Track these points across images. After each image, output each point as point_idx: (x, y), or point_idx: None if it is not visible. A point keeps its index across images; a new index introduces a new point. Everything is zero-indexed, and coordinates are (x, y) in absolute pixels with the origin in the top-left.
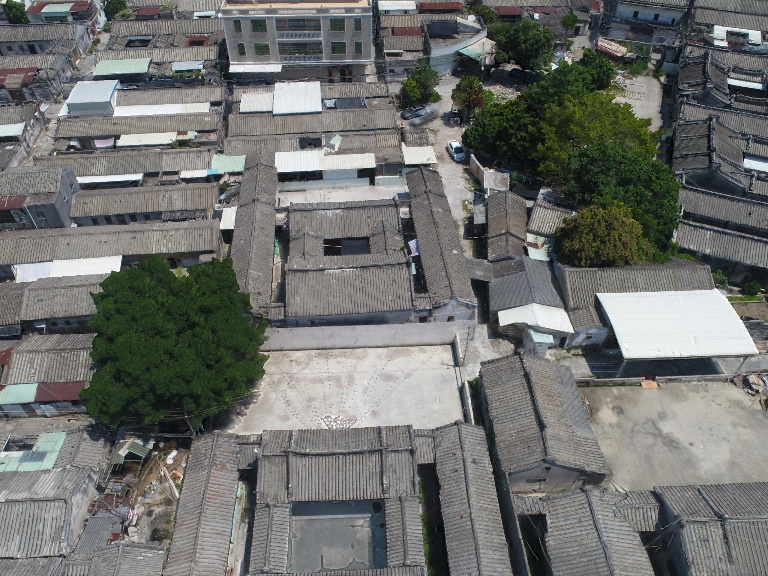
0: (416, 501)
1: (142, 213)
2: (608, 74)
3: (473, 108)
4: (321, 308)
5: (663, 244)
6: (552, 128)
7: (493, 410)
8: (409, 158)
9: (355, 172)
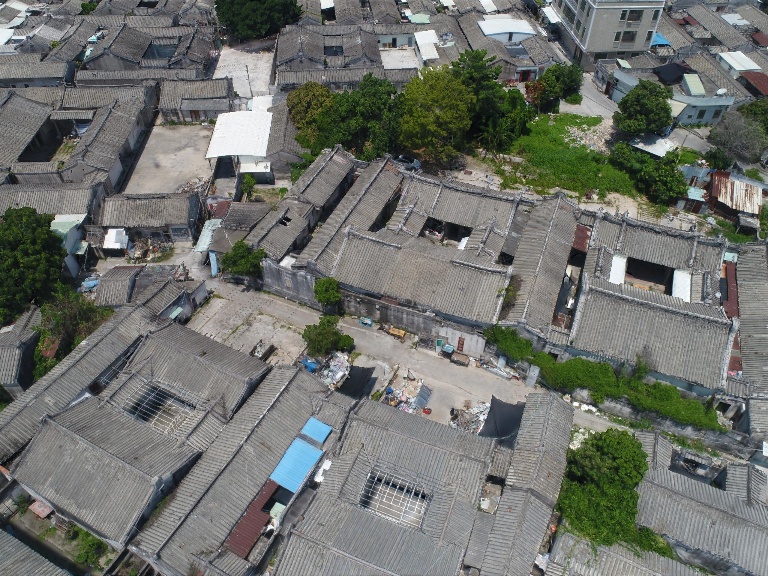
0: (167, 64)
1: None
2: None
3: None
4: None
5: None
6: None
7: None
8: None
9: None
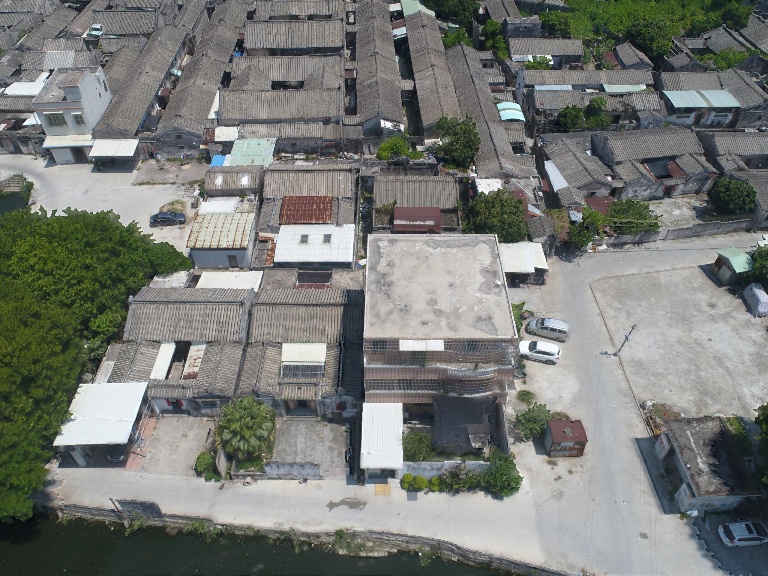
0: (172, 7)
1: None
2: None
3: None
4: None
5: None
6: None
7: None
8: None
9: None
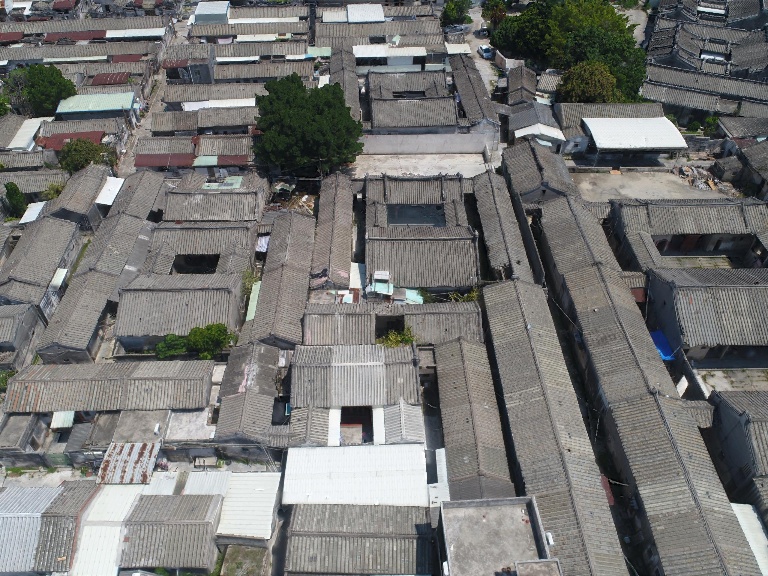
0: (463, 204)
1: (263, 78)
2: (604, 4)
3: (498, 24)
4: (396, 122)
5: (632, 97)
6: (556, 22)
7: (510, 169)
8: (451, 50)
9: (411, 59)
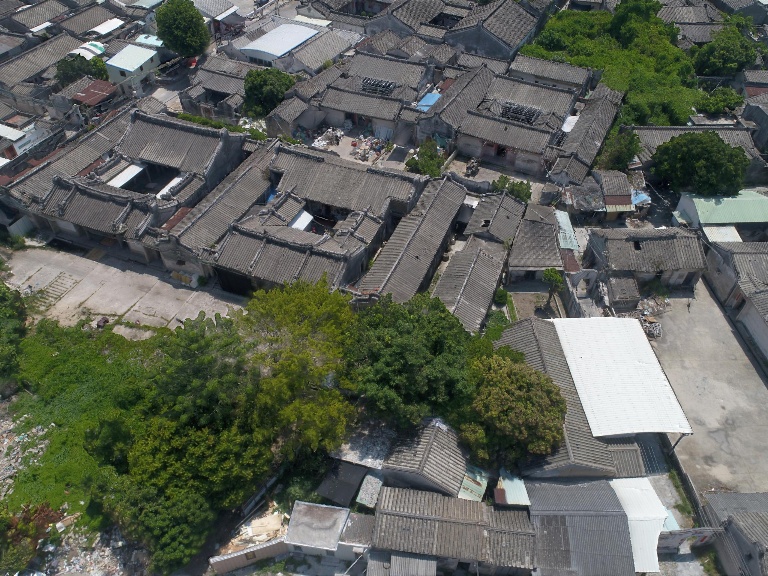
0: None
1: None
2: (16, 296)
3: None
4: None
5: None
6: None
7: None
8: None
9: None
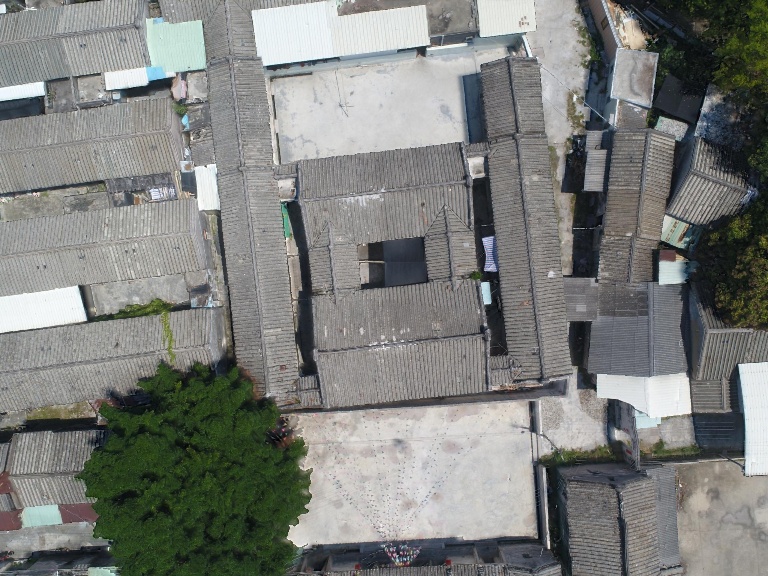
0: None
1: None
2: None
3: None
4: (368, 396)
5: None
6: None
7: (574, 546)
8: (488, 20)
9: None
